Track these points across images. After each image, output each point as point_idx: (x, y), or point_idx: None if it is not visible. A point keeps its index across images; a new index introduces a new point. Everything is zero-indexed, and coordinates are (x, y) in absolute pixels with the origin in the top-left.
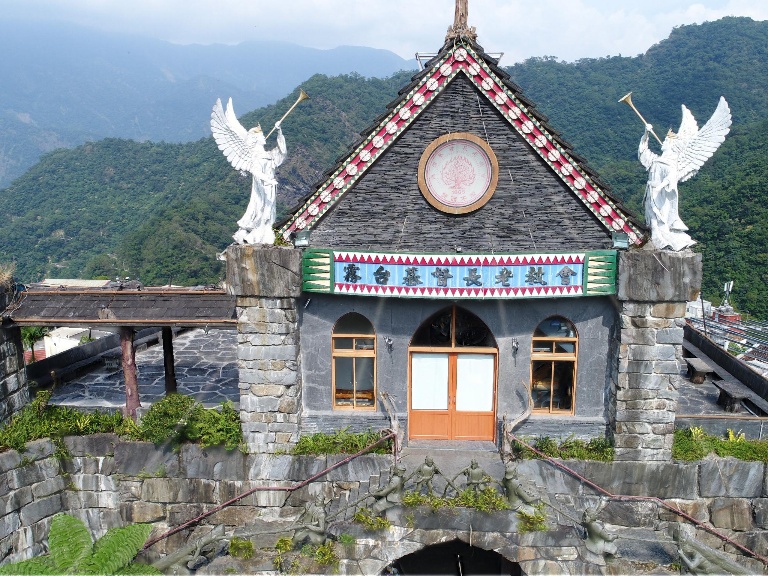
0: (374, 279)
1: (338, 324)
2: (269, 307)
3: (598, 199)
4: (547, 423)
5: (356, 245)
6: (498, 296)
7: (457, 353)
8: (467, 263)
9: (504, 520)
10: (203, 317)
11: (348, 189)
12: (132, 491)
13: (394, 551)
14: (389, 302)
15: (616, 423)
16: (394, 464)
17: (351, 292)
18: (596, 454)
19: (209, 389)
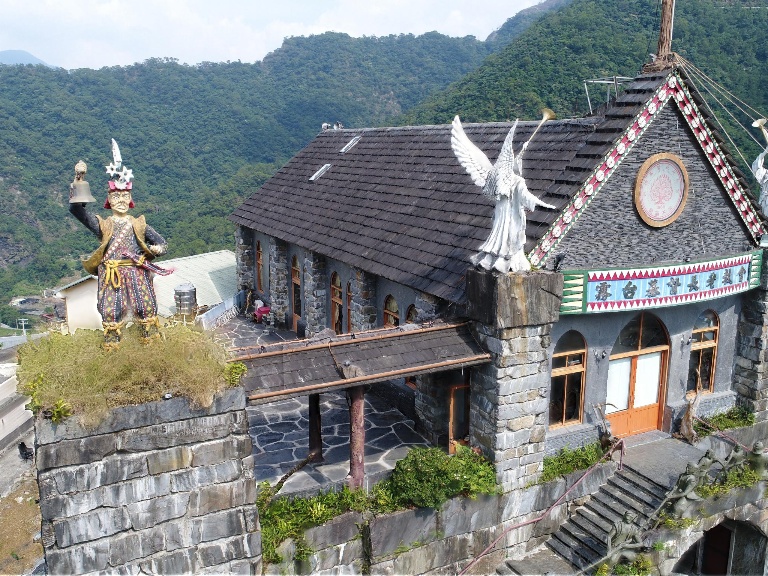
0: (622, 295)
1: (557, 344)
2: (531, 336)
3: (746, 208)
4: (703, 403)
5: (583, 263)
6: (708, 298)
7: (639, 355)
8: (692, 271)
9: (756, 491)
10: (447, 357)
11: (584, 209)
12: (388, 572)
13: (686, 546)
14: (599, 316)
15: (756, 392)
16: (617, 469)
17: (603, 310)
18: (740, 421)
19: (337, 442)
